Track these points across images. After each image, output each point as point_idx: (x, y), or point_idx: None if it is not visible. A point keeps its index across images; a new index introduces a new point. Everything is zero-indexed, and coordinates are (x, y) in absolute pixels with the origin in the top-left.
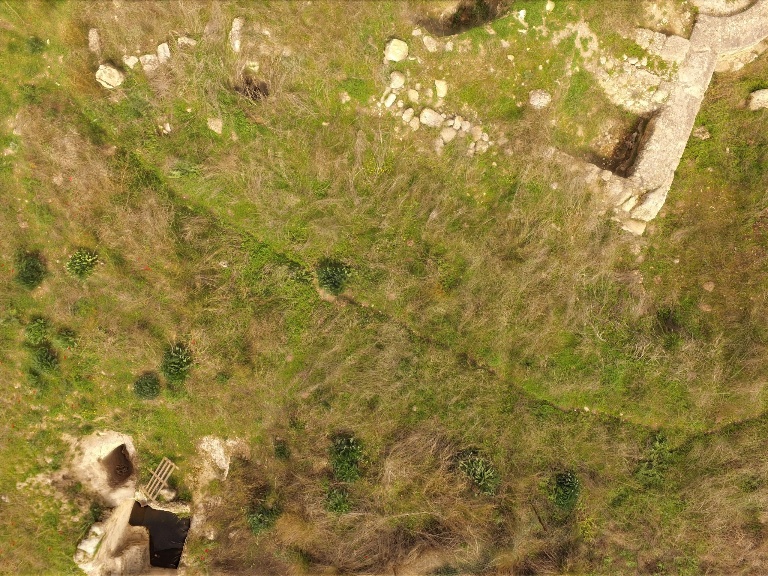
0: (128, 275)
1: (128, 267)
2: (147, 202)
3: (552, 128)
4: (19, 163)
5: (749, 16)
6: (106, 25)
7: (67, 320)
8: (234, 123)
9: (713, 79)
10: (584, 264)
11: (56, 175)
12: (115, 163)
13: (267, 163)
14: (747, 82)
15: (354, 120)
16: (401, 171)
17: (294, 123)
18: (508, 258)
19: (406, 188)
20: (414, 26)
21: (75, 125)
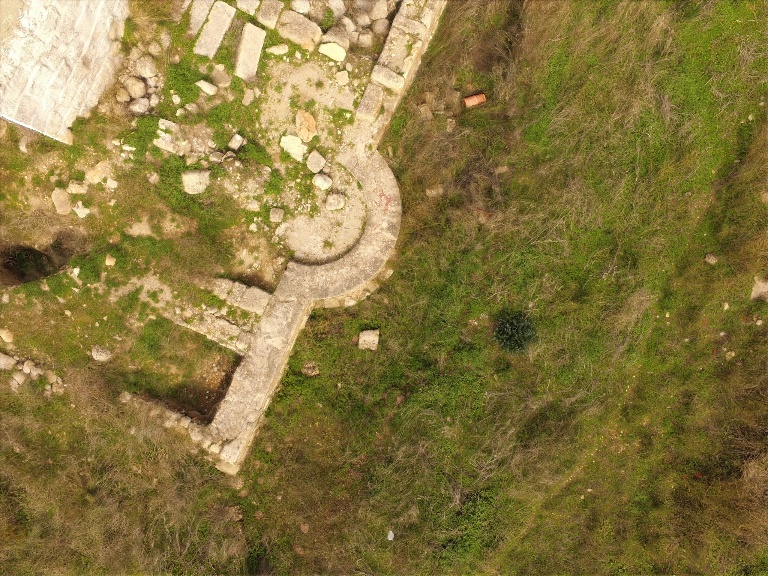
0: None
1: None
2: None
3: (130, 373)
4: None
5: (340, 266)
6: None
7: None
8: None
9: (325, 315)
10: (164, 508)
11: None
12: None
13: None
14: (357, 320)
15: None
16: None
17: None
18: (78, 504)
19: None
20: None
21: None
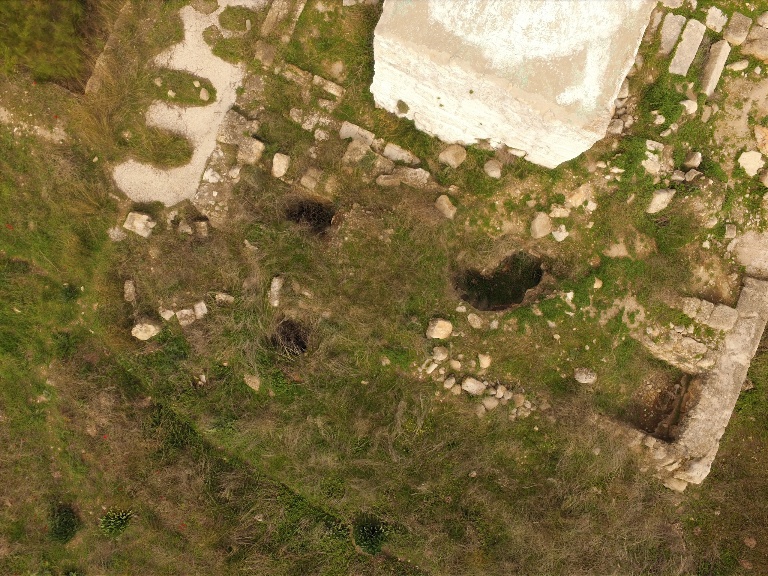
0: (162, 529)
1: (162, 520)
2: (184, 473)
3: (595, 395)
4: (52, 411)
5: None
6: (142, 277)
7: (100, 573)
8: (272, 385)
9: None
10: (625, 528)
11: (90, 426)
12: (150, 422)
13: (305, 425)
14: None
15: (394, 386)
16: (441, 437)
17: (333, 384)
18: (549, 527)
19: (445, 448)
20: (458, 302)
21: (109, 377)
